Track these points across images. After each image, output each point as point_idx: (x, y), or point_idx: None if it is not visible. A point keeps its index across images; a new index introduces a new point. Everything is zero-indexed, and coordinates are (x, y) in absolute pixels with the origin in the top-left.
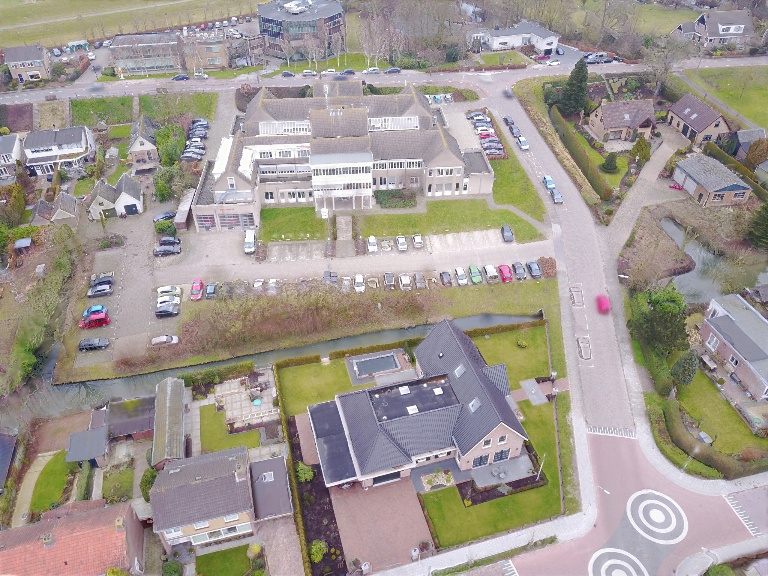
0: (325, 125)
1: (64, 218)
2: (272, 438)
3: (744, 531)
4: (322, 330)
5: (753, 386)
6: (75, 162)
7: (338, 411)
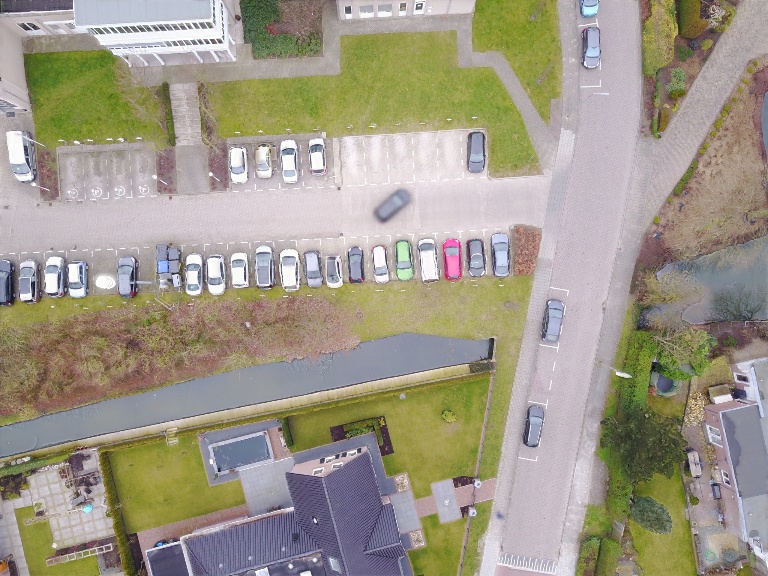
0: None
1: None
2: (113, 566)
3: None
4: None
5: (731, 519)
6: None
7: (185, 562)
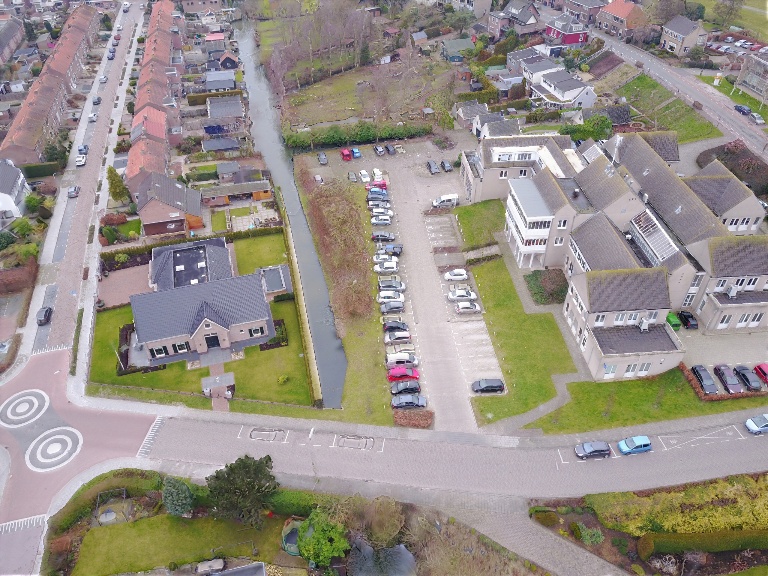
0: (592, 175)
1: (461, 116)
2: None
3: (6, 519)
4: (326, 252)
5: None
6: (549, 104)
7: None
